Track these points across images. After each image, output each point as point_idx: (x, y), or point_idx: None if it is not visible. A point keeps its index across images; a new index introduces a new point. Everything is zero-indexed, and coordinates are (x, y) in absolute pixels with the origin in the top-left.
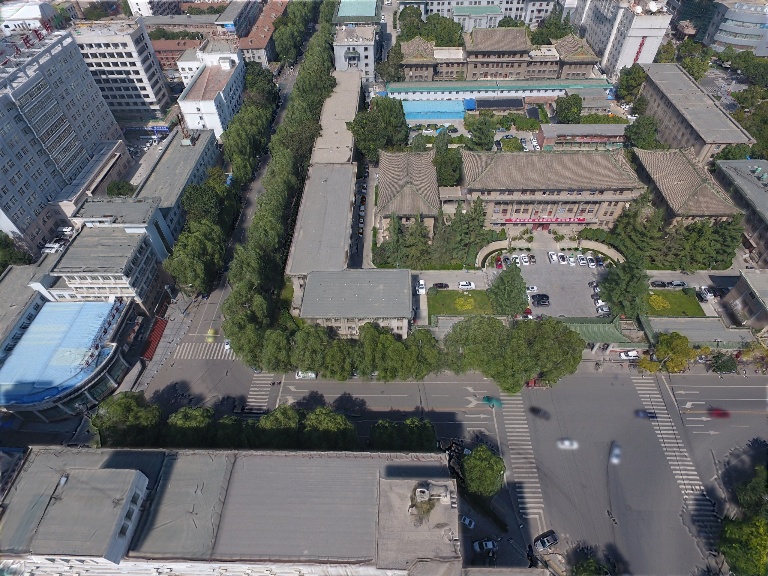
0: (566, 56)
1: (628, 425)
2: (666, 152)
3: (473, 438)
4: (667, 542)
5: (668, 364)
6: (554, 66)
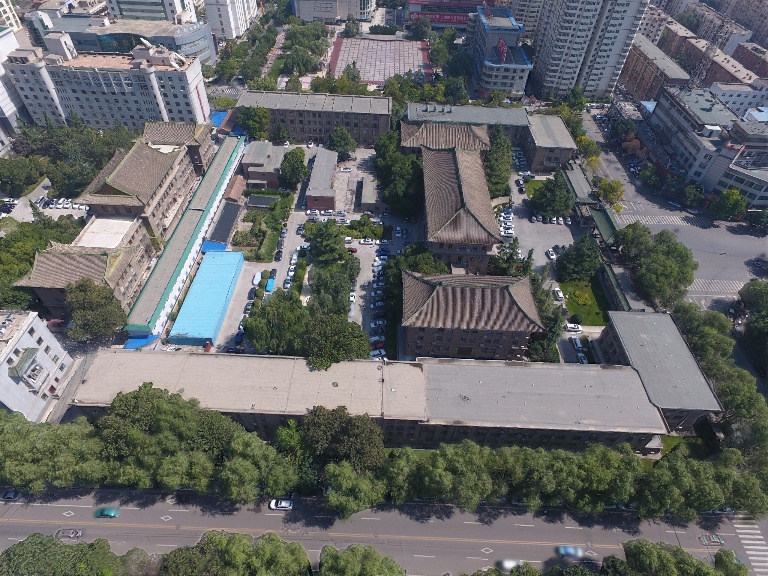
0: (193, 140)
1: (655, 233)
2: (420, 131)
3: (713, 309)
4: (722, 237)
5: (621, 198)
6: (186, 158)
